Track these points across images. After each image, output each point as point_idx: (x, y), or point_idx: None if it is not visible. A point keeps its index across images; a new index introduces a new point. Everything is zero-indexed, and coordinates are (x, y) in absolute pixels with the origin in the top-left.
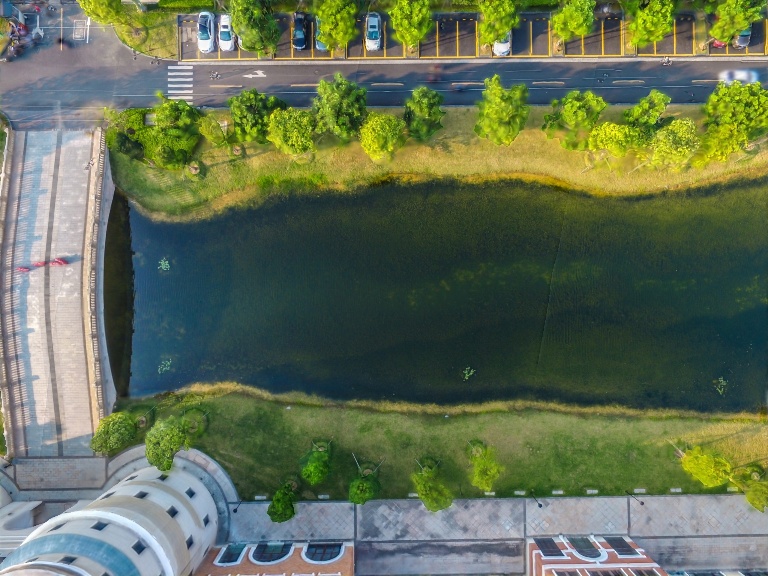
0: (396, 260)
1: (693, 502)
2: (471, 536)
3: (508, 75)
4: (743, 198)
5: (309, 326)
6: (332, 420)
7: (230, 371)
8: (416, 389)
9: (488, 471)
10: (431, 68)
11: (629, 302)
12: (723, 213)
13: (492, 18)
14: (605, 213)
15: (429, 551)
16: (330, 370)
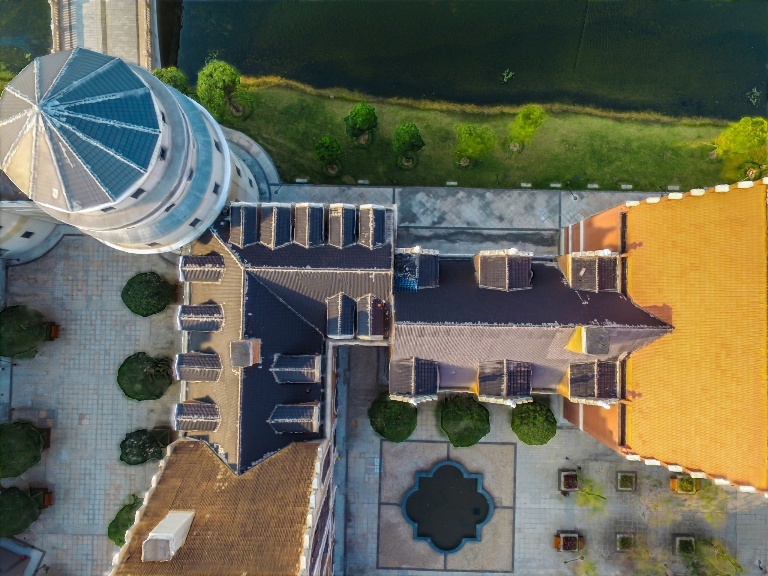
0: None
1: None
2: (507, 225)
3: None
4: None
5: (353, 27)
6: None
7: (275, 65)
8: (455, 89)
9: (531, 115)
10: None
11: (665, 15)
12: None
13: None
14: None
15: (465, 238)
16: (372, 68)
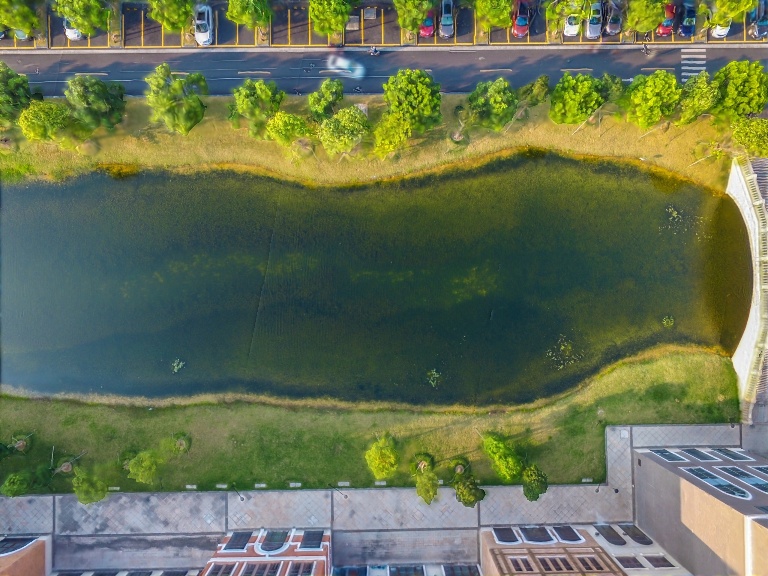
0: (106, 252)
1: (397, 495)
2: (172, 530)
3: (214, 65)
4: (458, 189)
5: (18, 318)
6: (36, 413)
7: None
8: (125, 382)
9: (143, 463)
10: (136, 58)
11: (344, 294)
12: (438, 204)
13: (155, 6)
14: (318, 204)
15: (129, 545)
16: (38, 363)
